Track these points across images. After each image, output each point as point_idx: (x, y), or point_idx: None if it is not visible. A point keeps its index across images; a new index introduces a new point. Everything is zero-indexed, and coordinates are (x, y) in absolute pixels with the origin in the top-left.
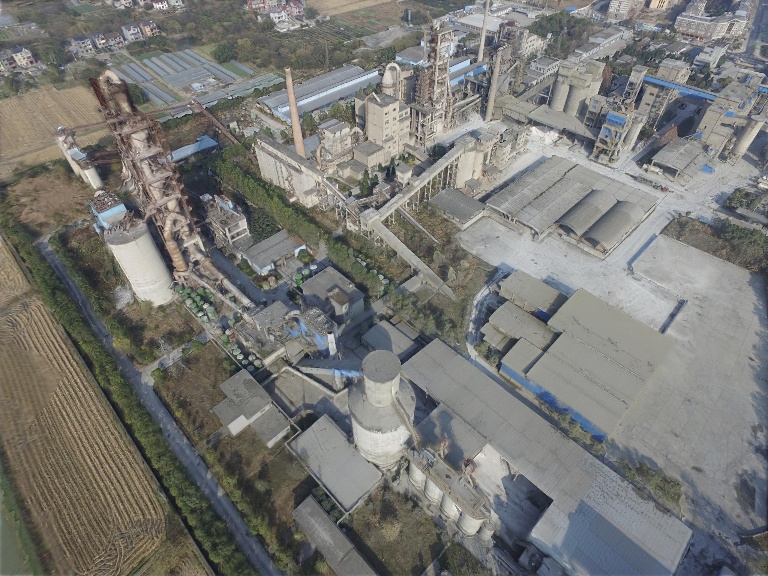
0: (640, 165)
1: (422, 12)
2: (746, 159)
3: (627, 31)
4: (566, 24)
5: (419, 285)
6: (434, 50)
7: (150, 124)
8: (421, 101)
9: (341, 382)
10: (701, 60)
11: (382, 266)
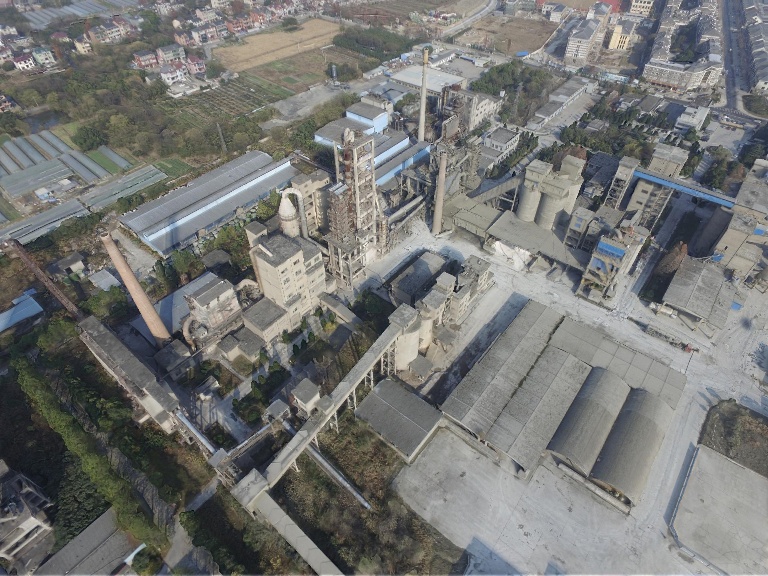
0: (644, 301)
1: (349, 66)
2: None
3: (591, 84)
4: (520, 76)
5: None
6: (350, 167)
7: None
8: (339, 234)
9: None
10: (684, 123)
11: (276, 575)
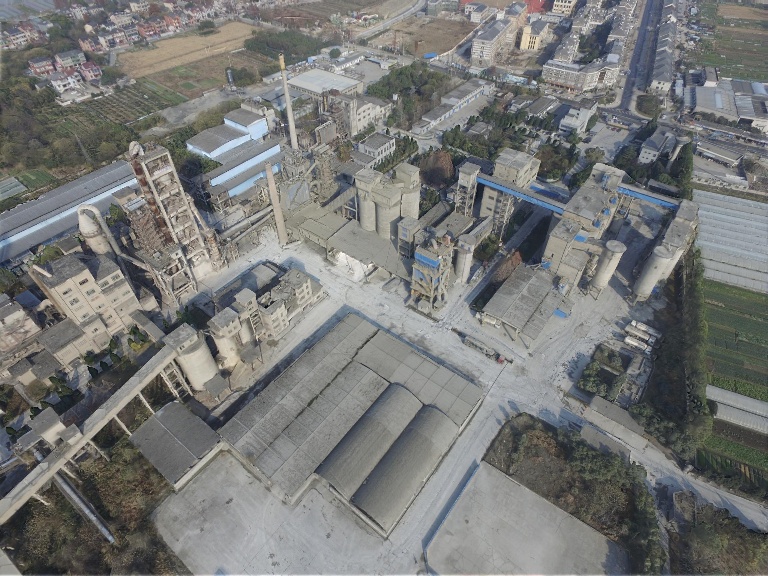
0: (474, 310)
1: (248, 70)
2: (613, 285)
3: (487, 86)
4: (419, 79)
5: None
6: (147, 181)
7: None
8: (149, 249)
9: None
10: (567, 125)
11: None
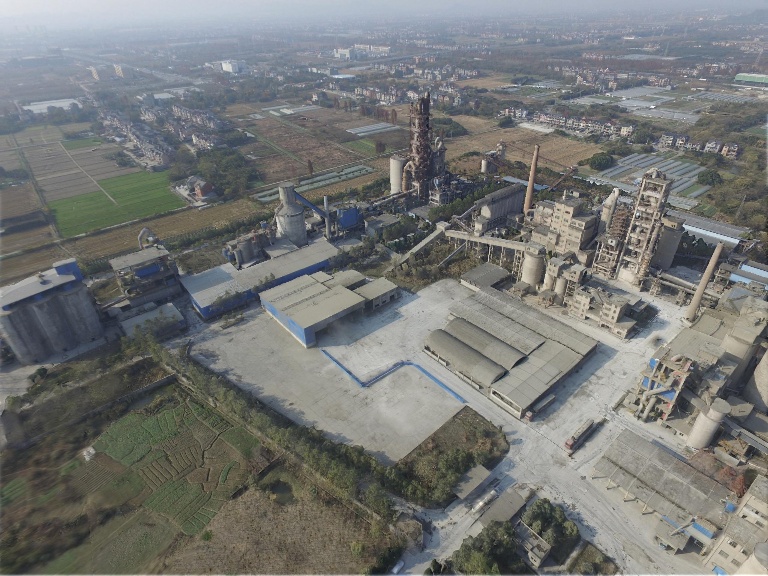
0: None
1: None
2: None
3: None
4: None
5: None
6: None
7: (420, 117)
8: None
9: (329, 235)
10: None
11: None
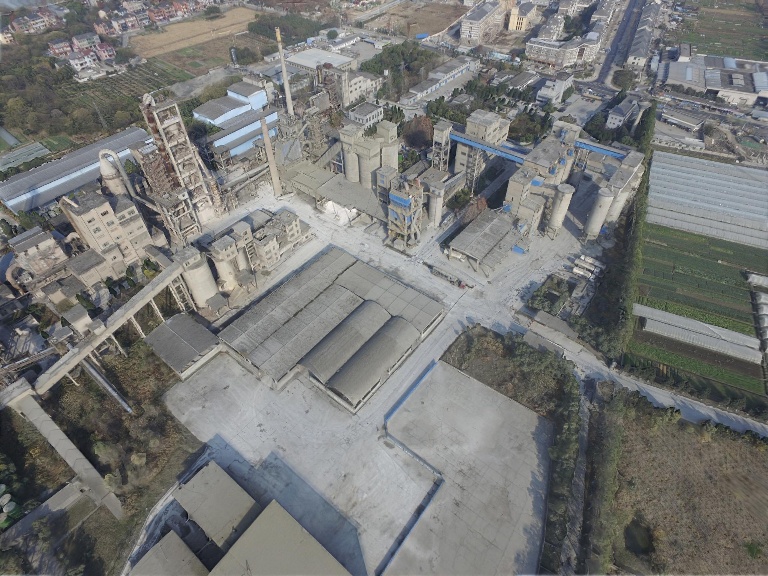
0: (443, 248)
1: (250, 49)
2: (569, 228)
3: (473, 62)
4: (409, 56)
5: (77, 495)
6: None
7: None
8: (160, 191)
9: None
10: (543, 96)
11: (37, 463)
